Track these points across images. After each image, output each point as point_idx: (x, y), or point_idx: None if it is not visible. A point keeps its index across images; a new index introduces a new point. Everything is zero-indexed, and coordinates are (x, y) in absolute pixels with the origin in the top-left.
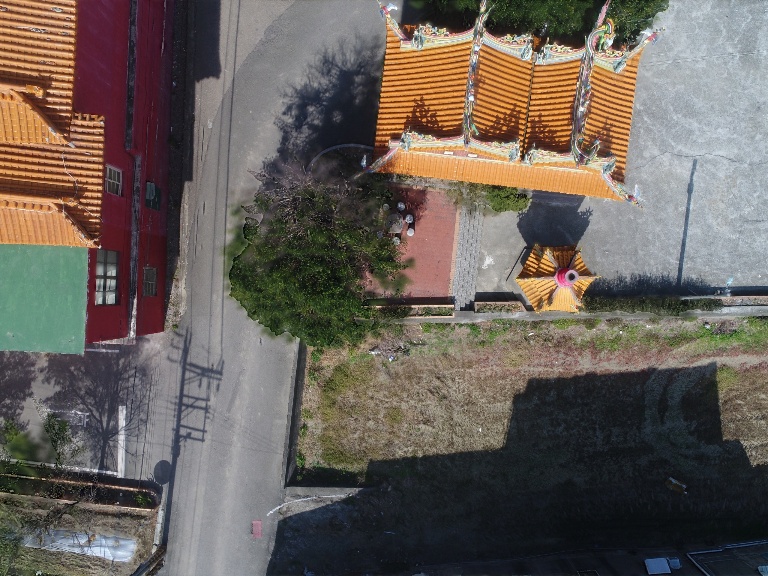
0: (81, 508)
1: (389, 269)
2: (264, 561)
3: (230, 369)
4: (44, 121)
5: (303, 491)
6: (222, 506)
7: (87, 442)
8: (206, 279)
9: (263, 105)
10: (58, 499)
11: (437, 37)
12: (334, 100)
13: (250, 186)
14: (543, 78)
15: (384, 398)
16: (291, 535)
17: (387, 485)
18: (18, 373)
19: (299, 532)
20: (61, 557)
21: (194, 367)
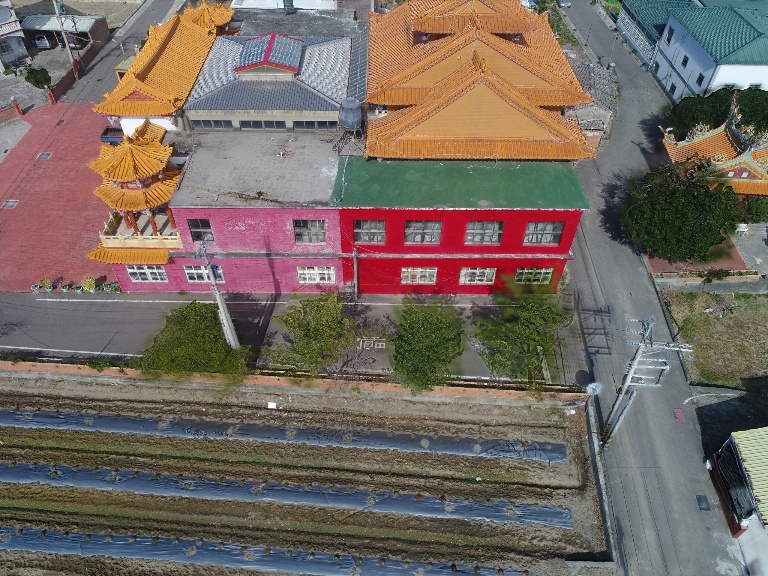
0: (508, 423)
1: (700, 258)
2: (697, 440)
3: (615, 310)
4: (582, 92)
5: (703, 389)
6: (643, 398)
7: (514, 361)
8: (580, 263)
9: (588, 189)
10: (507, 390)
11: (702, 133)
12: (627, 189)
13: (594, 220)
14: (760, 153)
15: (728, 339)
16: (710, 421)
17: (765, 391)
18: (450, 320)
19: (715, 419)
20: (499, 461)
21: (587, 311)
